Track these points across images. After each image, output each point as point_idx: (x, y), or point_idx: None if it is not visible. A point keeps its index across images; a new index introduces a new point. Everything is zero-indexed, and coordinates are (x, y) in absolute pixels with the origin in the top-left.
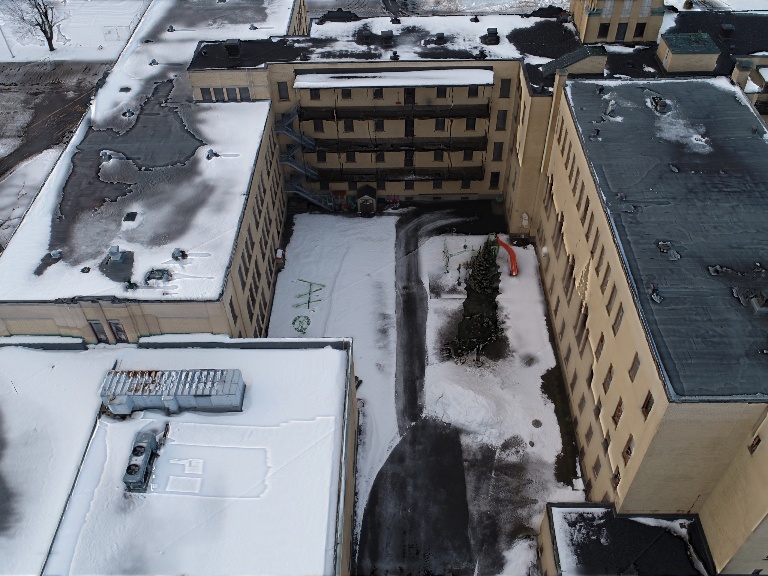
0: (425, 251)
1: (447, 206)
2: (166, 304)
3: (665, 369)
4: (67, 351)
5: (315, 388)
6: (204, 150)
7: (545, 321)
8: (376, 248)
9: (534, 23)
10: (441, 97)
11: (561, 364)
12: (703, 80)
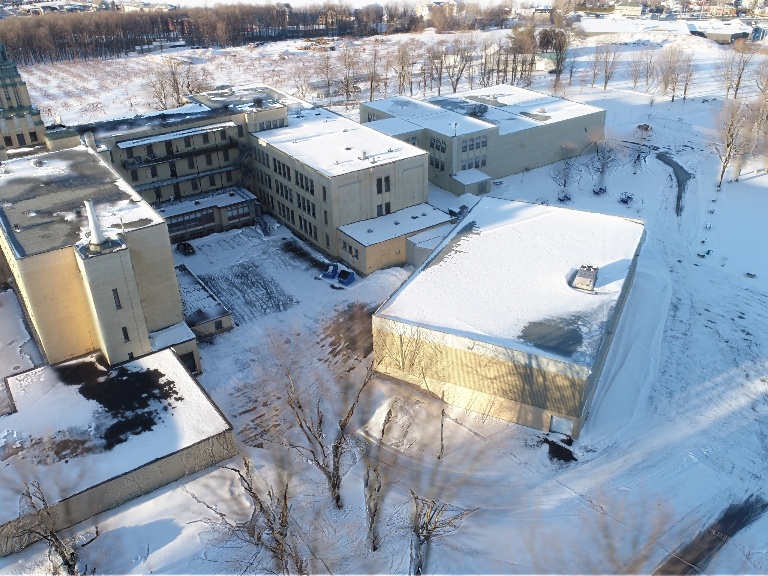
0: None
1: None
2: None
3: (17, 251)
4: None
5: None
6: None
7: (22, 321)
8: None
9: None
10: None
11: None
12: (69, 149)
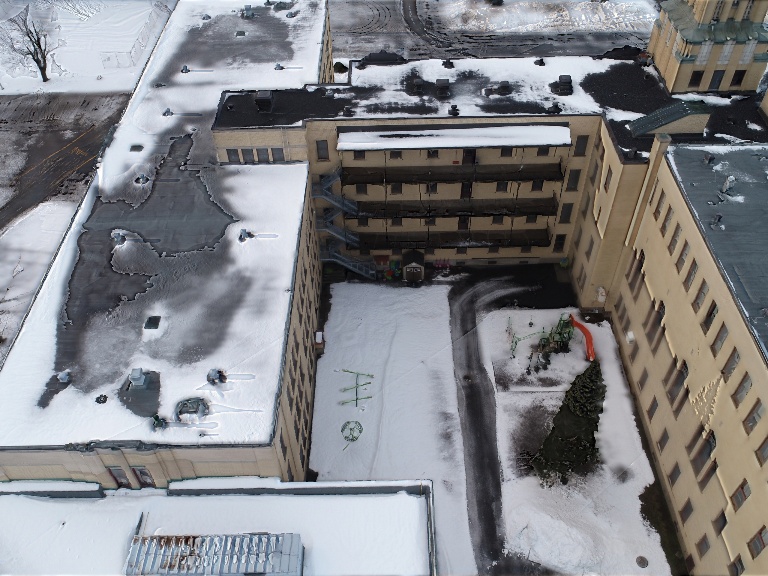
0: (485, 330)
1: (504, 272)
2: (204, 449)
3: None
4: (80, 500)
5: (391, 552)
6: (235, 229)
7: (634, 421)
8: (428, 327)
9: (609, 67)
10: (506, 156)
11: (661, 480)
12: None
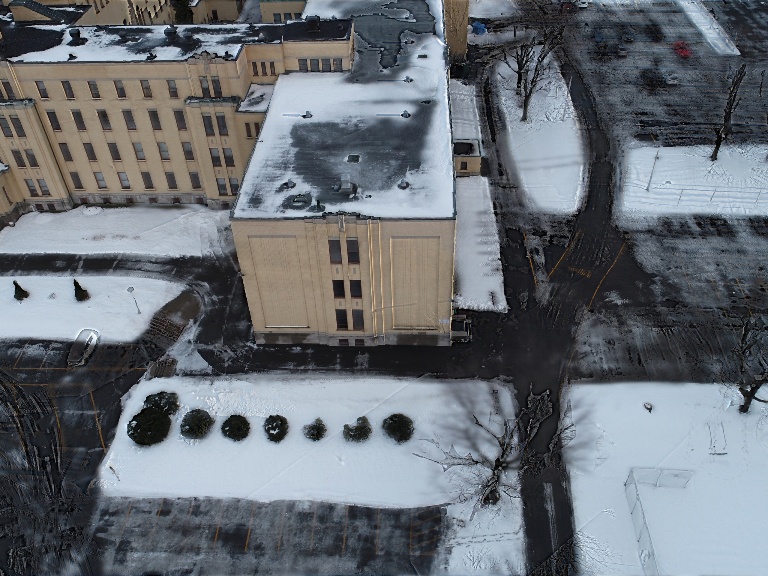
0: None
1: None
2: None
3: None
4: None
5: None
6: None
7: None
8: None
9: None
10: None
11: None
12: None
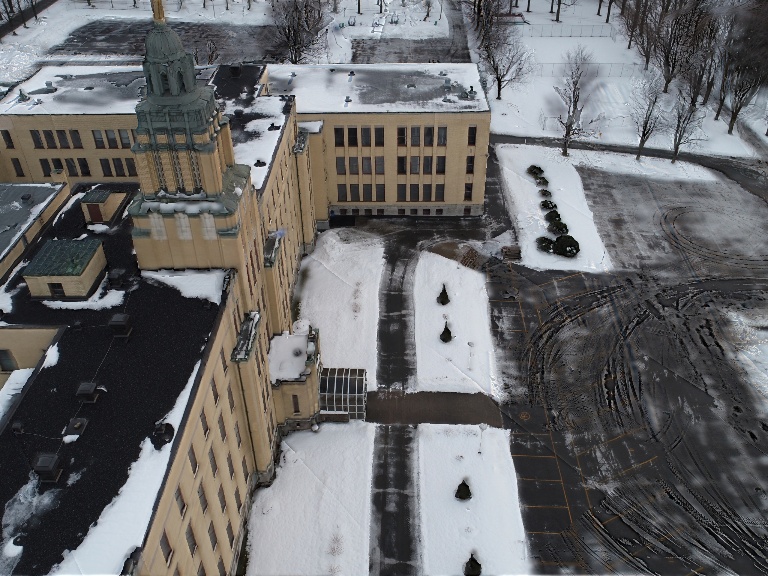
0: None
1: None
2: None
3: None
4: None
5: None
6: None
7: None
8: None
9: None
10: None
11: None
12: None
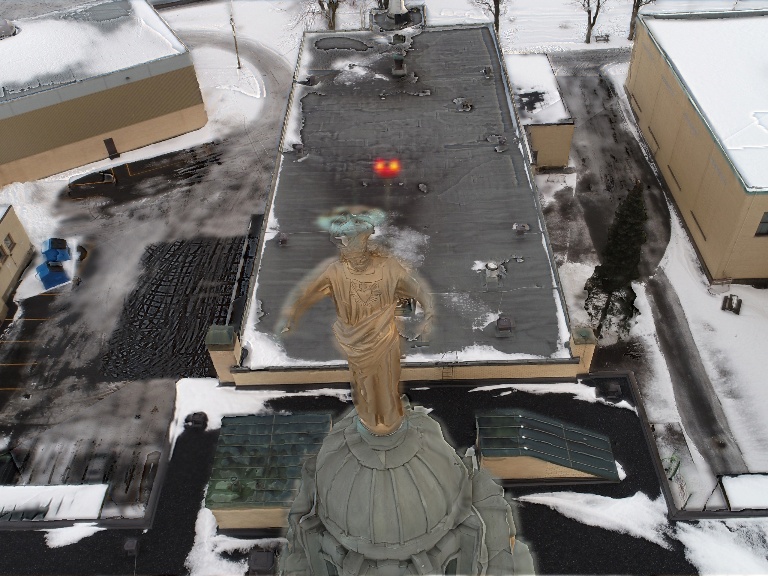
0: None
1: None
2: None
3: None
4: None
5: (759, 165)
6: None
7: None
8: None
9: None
10: None
11: None
12: (297, 361)
